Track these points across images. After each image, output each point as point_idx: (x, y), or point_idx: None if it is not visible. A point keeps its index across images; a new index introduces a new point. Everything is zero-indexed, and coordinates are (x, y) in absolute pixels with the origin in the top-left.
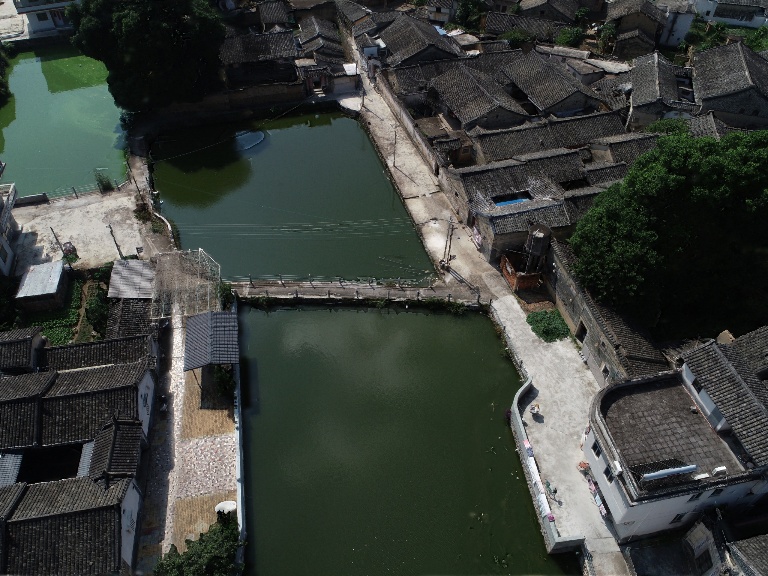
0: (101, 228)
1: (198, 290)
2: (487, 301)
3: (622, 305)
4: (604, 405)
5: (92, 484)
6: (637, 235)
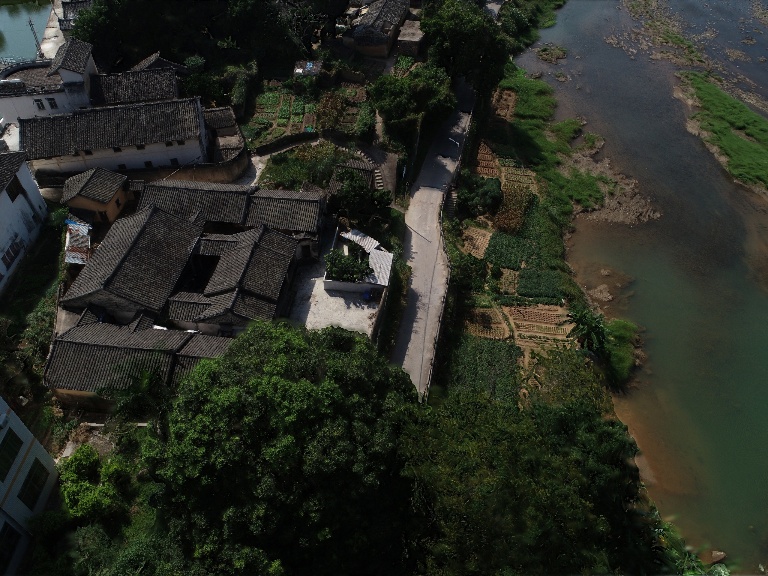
0: None
1: None
2: None
3: (96, 52)
4: (15, 71)
5: None
6: (96, 8)
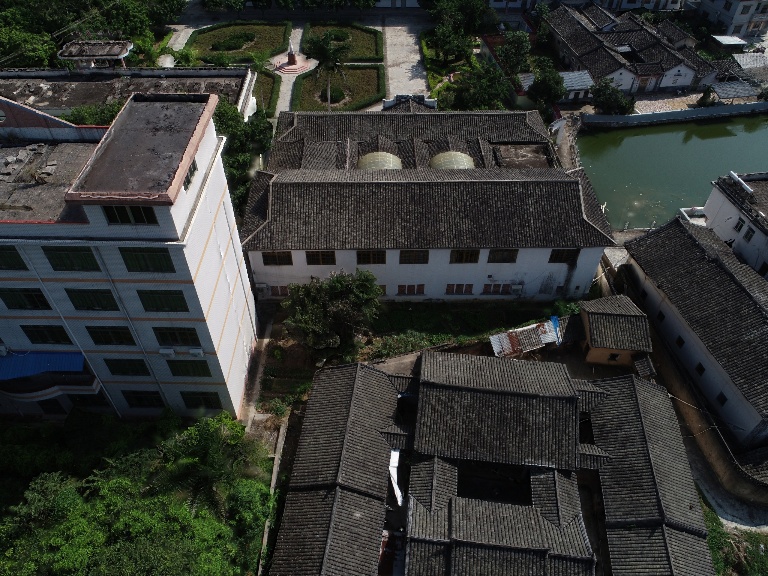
0: None
1: None
2: None
3: None
4: None
5: (628, 64)
6: None
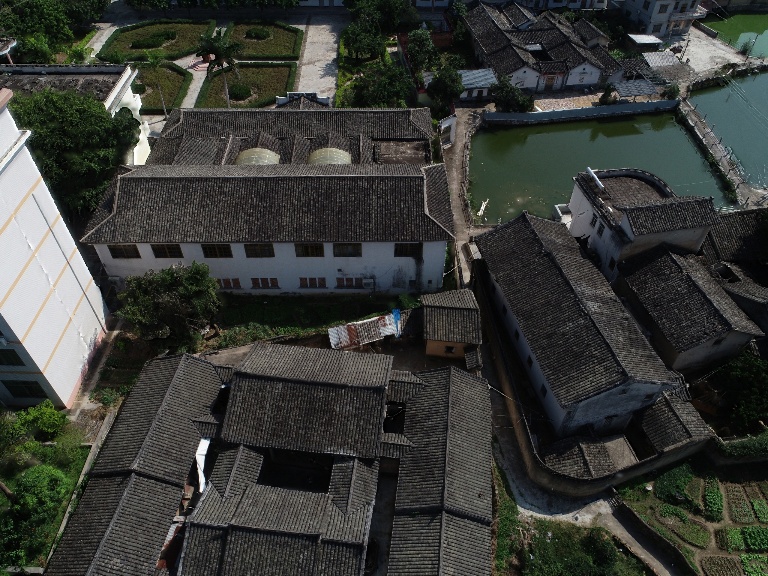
0: (704, 57)
1: (666, 78)
2: (749, 208)
3: (767, 233)
4: (641, 179)
5: None
6: None
